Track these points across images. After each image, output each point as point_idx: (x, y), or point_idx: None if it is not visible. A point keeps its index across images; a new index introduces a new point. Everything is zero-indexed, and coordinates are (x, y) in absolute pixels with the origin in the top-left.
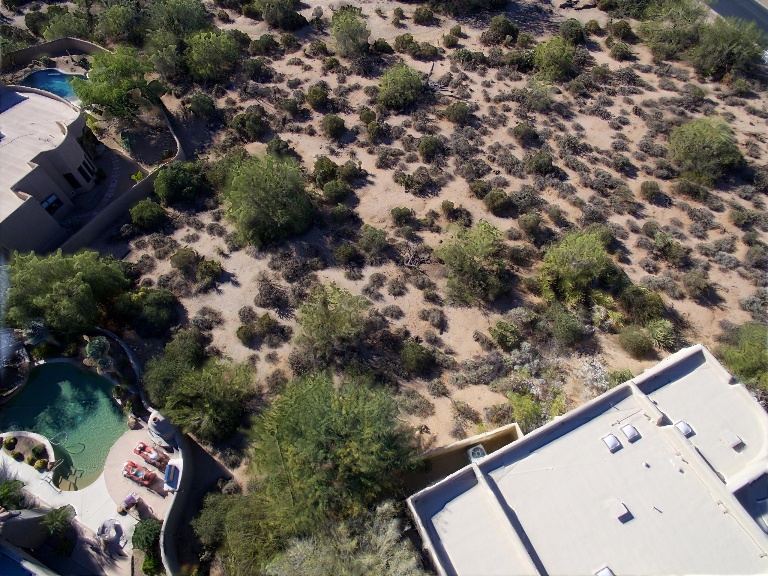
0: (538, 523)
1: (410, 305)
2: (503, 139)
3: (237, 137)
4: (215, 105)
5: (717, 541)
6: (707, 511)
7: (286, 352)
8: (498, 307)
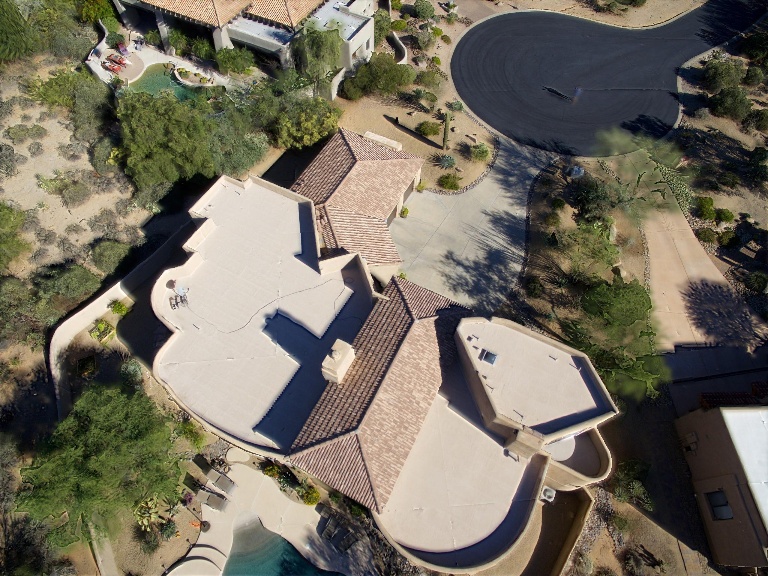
0: None
1: None
2: None
3: None
4: None
5: None
6: None
7: (14, 121)
8: None
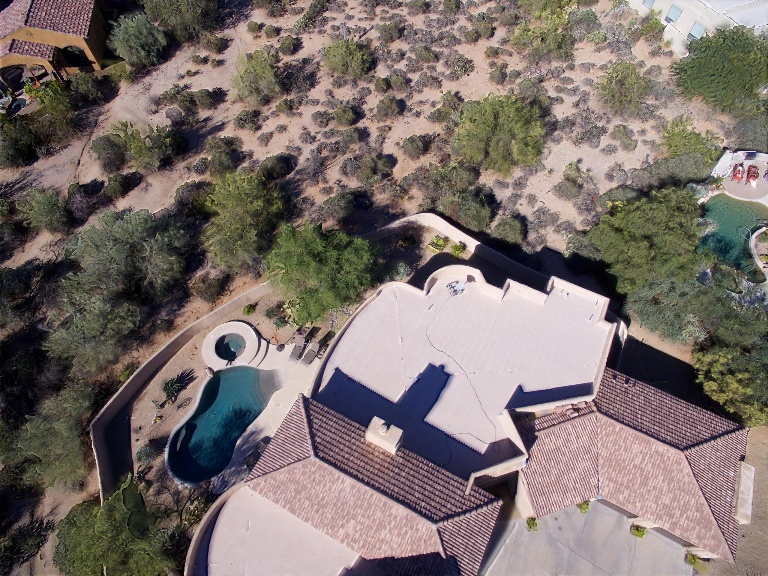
0: (733, 5)
1: (580, 76)
2: (419, 20)
3: None
4: None
5: None
6: None
7: (636, 126)
8: None
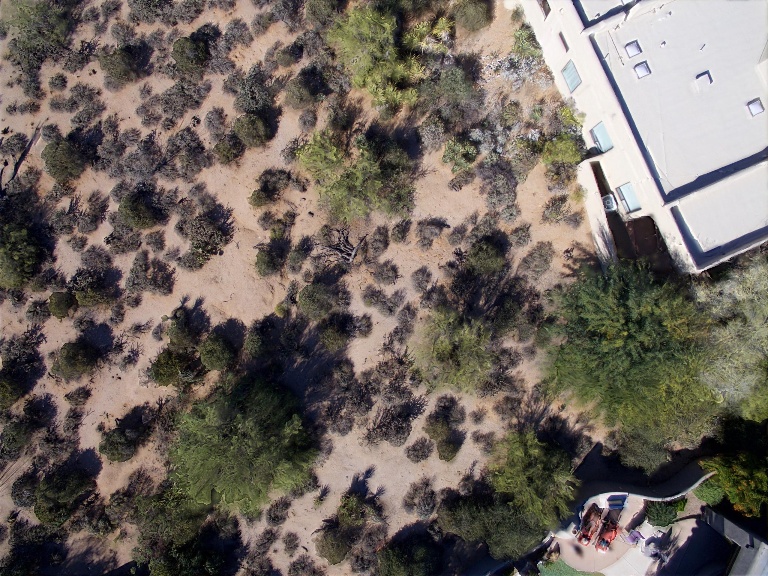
0: (710, 157)
1: (411, 260)
2: (129, 101)
3: (85, 513)
4: (1, 562)
5: (730, 5)
6: (706, 4)
7: (471, 402)
8: (414, 158)
